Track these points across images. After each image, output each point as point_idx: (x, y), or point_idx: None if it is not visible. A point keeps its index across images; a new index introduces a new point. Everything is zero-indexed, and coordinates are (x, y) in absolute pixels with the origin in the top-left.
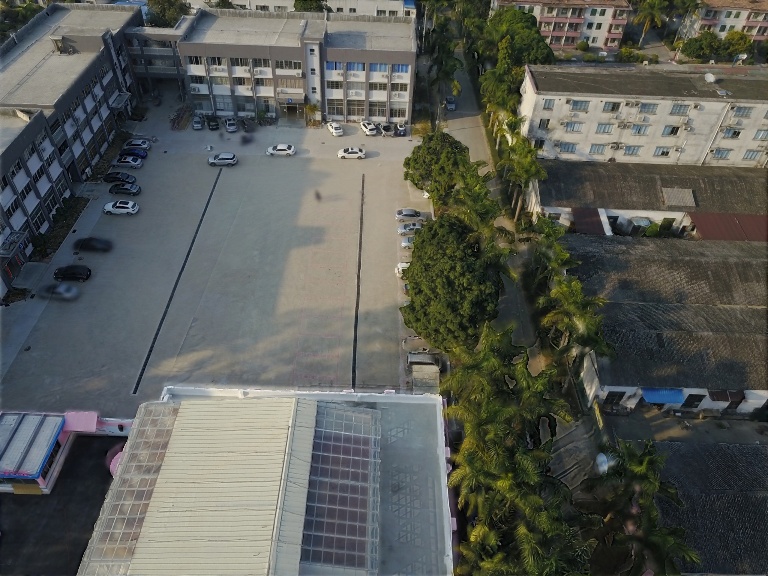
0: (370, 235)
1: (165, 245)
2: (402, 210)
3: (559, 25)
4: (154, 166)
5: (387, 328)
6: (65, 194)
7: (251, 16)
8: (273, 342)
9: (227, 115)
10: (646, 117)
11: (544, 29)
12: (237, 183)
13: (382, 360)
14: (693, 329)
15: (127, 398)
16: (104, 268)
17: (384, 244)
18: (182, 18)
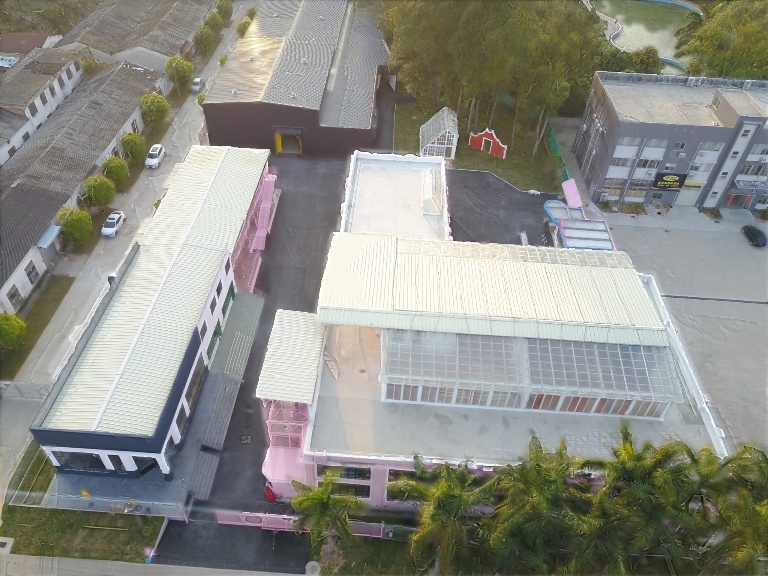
0: None
1: None
2: None
3: None
4: None
5: None
6: None
7: None
8: (761, 384)
9: None
10: None
11: None
12: None
13: None
14: None
15: None
16: None
17: None
18: None
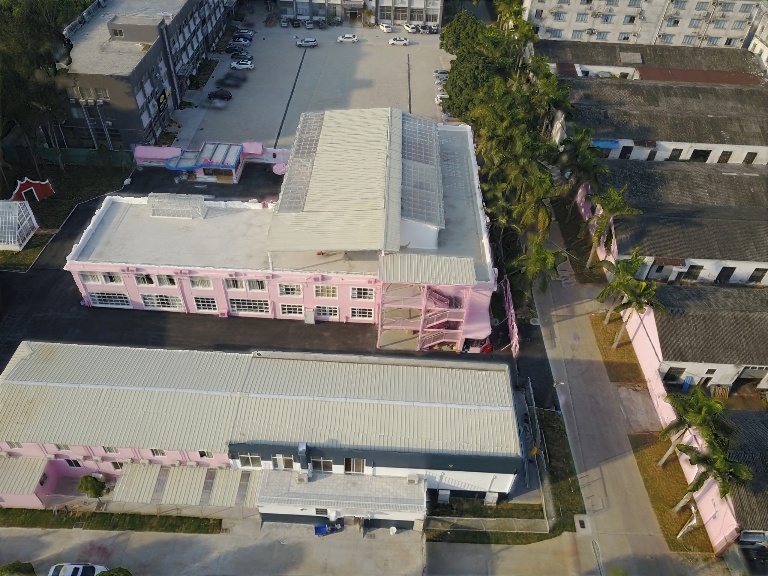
0: (416, 85)
1: (276, 86)
2: (438, 70)
3: None
4: (258, 46)
5: None
6: (203, 56)
7: None
8: None
9: (305, 19)
10: (611, 8)
11: None
12: (319, 56)
13: None
14: (627, 110)
15: None
16: (239, 95)
17: (426, 89)
18: None
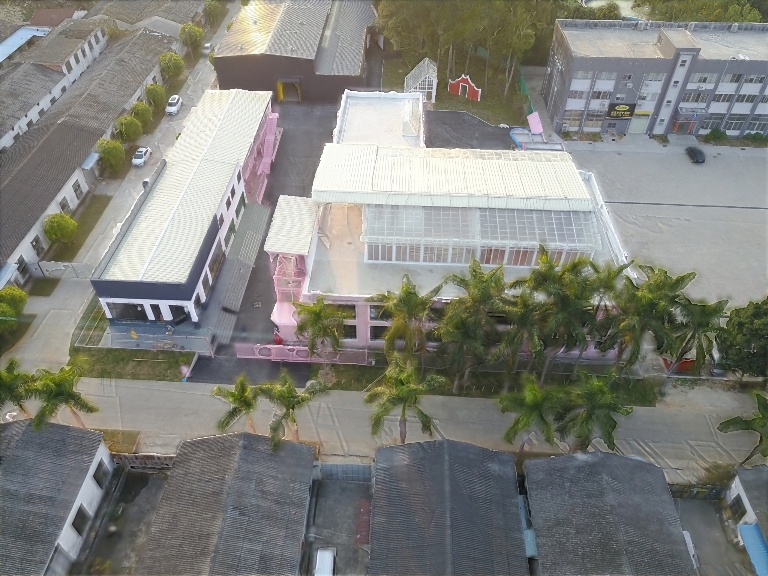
0: None
1: (763, 194)
2: None
3: None
4: None
5: None
6: None
7: None
8: (688, 263)
9: None
10: None
11: None
12: None
13: None
14: None
15: None
16: (713, 169)
17: None
18: None
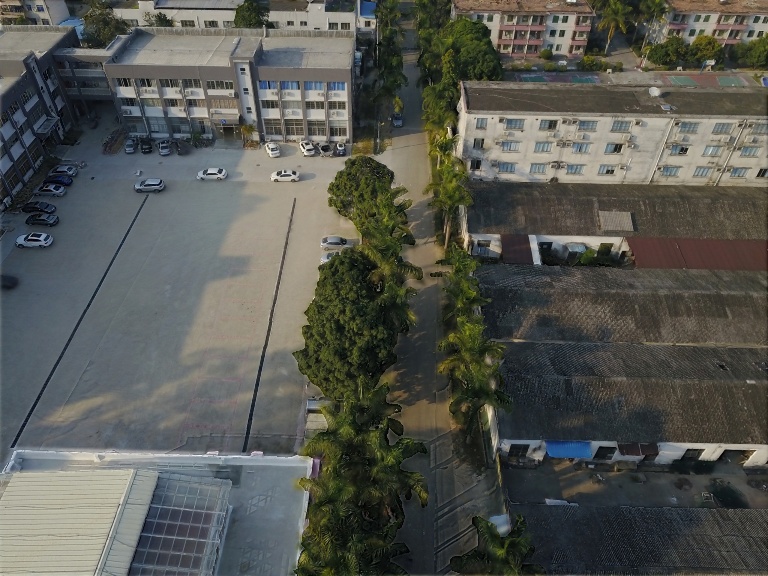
0: (292, 265)
1: (74, 280)
2: (327, 238)
3: (520, 33)
4: (78, 194)
5: (293, 369)
6: None
7: (188, 34)
8: (169, 387)
9: (162, 137)
10: (586, 135)
11: (505, 38)
12: (161, 210)
13: (282, 406)
14: (606, 374)
15: (4, 452)
16: (5, 307)
17: (305, 275)
18: (116, 38)
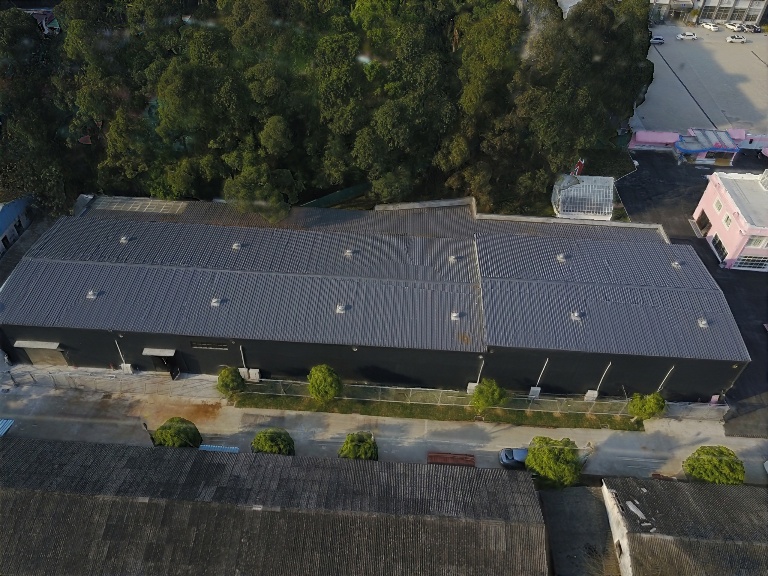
0: None
1: (664, 79)
2: None
3: None
4: None
5: None
6: None
7: None
8: None
9: None
10: None
11: None
12: (674, 53)
13: None
14: None
15: None
16: None
17: None
18: None
